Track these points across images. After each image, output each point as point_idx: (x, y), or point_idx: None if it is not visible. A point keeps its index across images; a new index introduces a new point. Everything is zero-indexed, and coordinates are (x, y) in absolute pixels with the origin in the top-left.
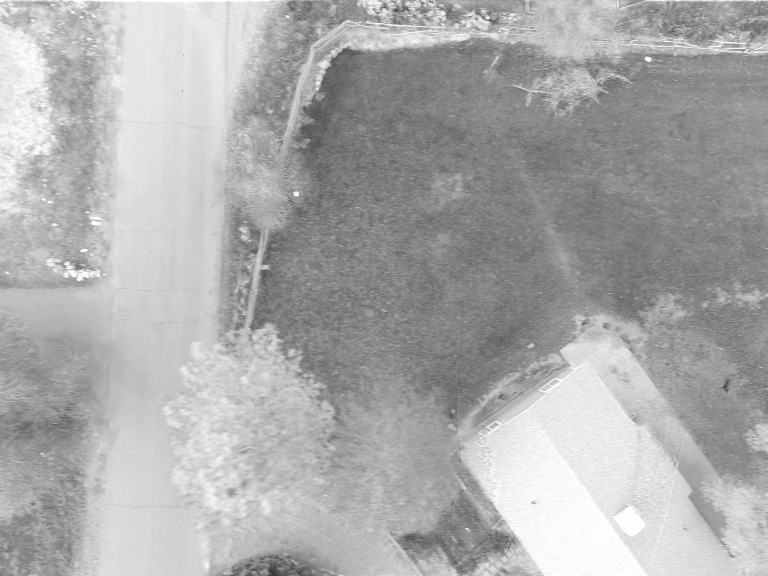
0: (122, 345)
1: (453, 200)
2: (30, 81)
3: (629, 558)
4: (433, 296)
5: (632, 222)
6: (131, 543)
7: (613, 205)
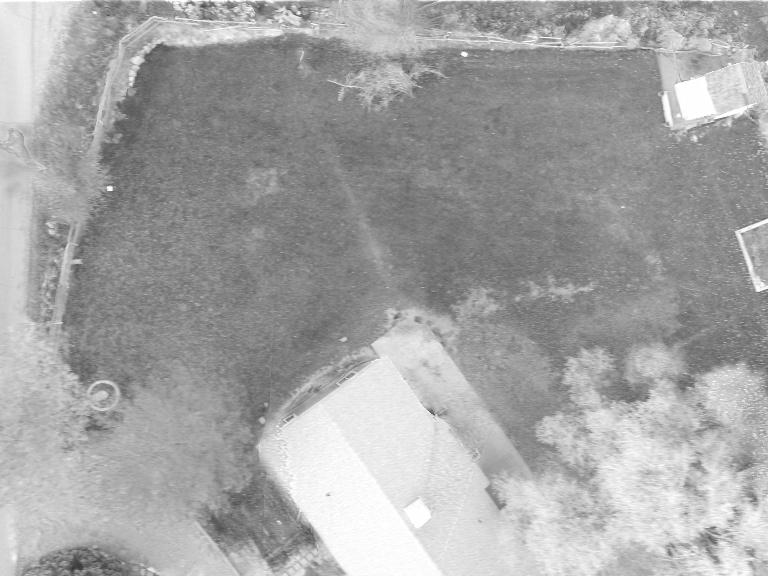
0: None
1: (267, 195)
2: None
3: (419, 550)
4: (247, 290)
5: (445, 216)
6: None
7: (426, 199)
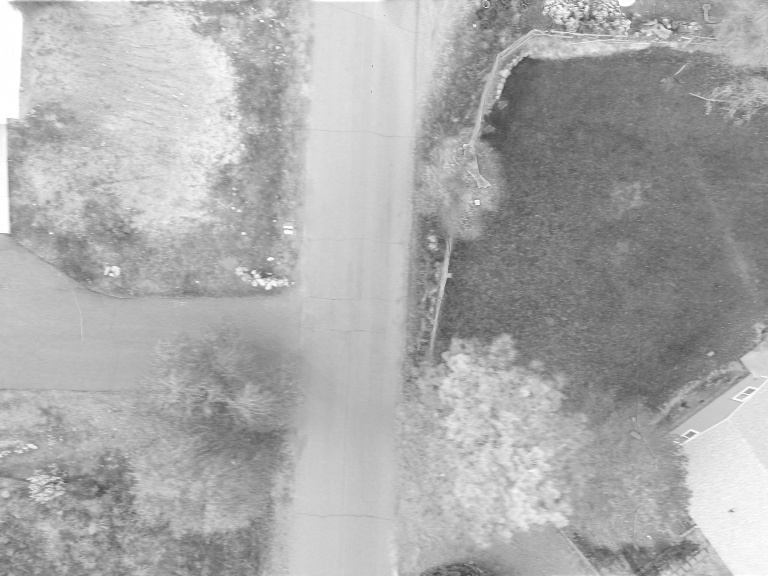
0: (310, 354)
1: (632, 208)
2: (220, 90)
3: None
4: (612, 304)
5: None
6: (320, 552)
7: None
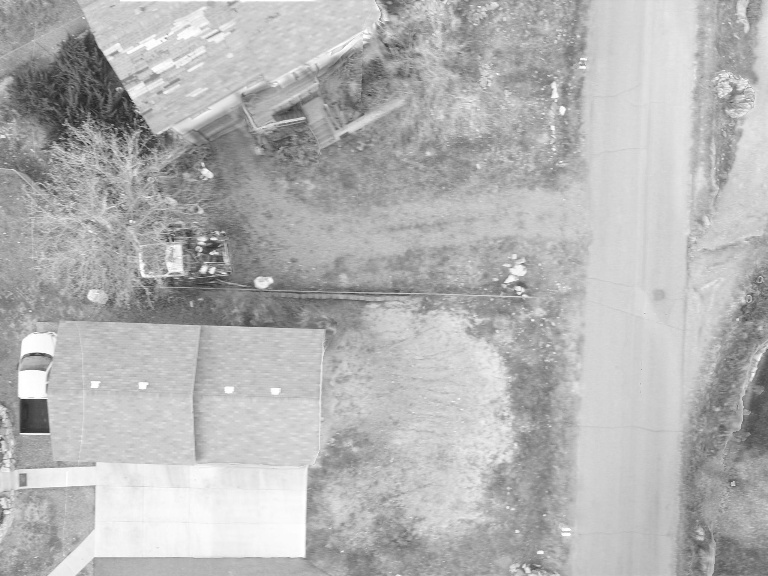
0: None
1: None
2: (493, 390)
3: None
4: None
5: None
6: None
7: None
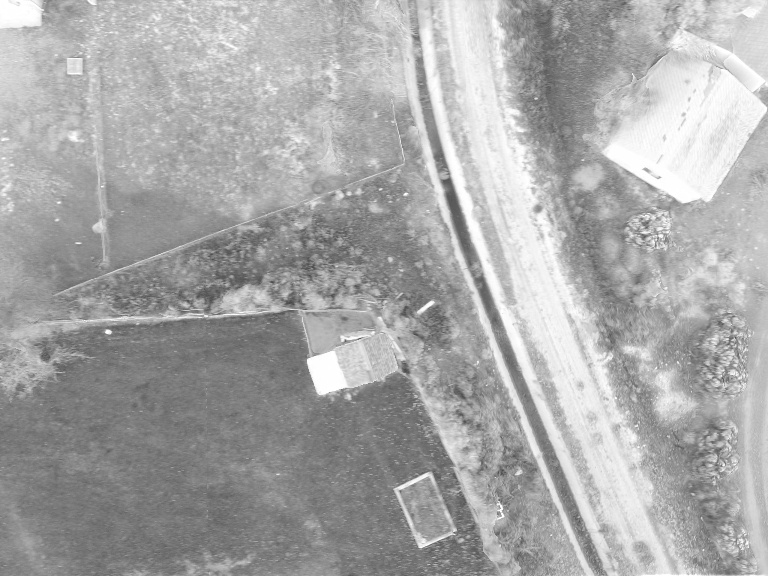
0: None
1: None
2: None
3: None
4: None
5: (95, 501)
6: None
7: (76, 485)
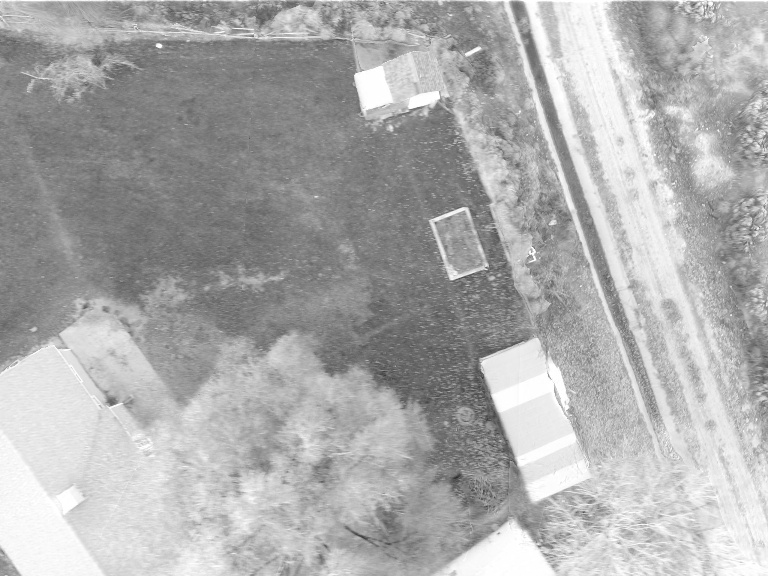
0: None
1: None
2: None
3: (72, 537)
4: None
5: (135, 207)
6: None
7: (117, 190)
